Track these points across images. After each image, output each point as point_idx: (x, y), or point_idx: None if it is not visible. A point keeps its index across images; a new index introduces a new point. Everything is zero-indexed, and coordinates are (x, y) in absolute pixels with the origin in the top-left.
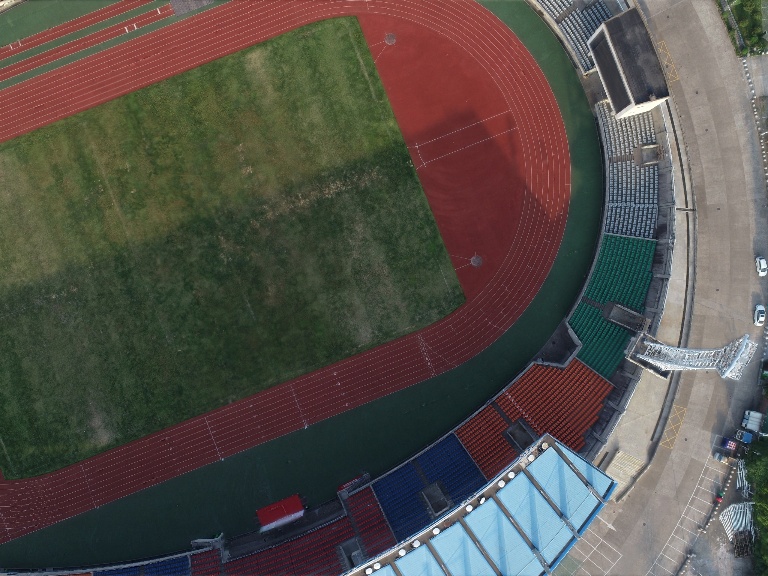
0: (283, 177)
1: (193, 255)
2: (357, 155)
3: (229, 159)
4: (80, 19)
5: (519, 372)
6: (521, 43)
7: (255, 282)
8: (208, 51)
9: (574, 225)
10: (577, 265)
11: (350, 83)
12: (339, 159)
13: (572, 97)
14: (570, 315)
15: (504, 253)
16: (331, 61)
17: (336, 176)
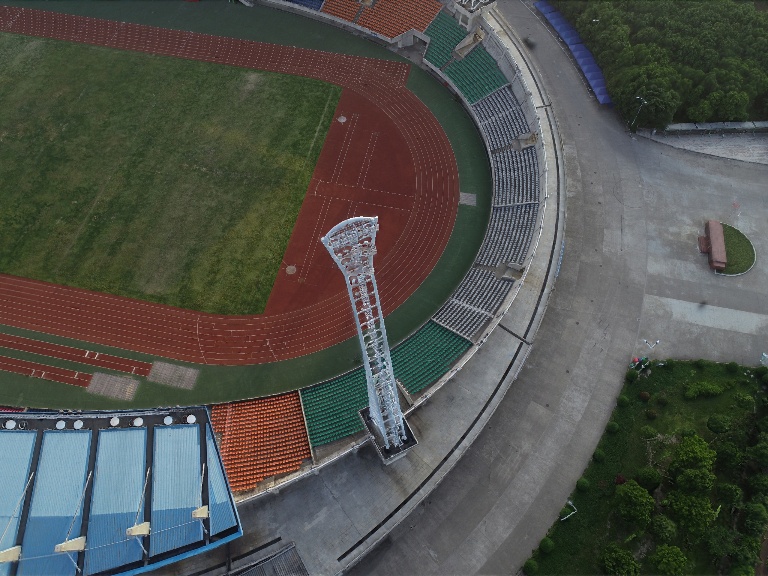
0: None
1: (81, 140)
2: None
3: None
4: None
5: None
6: None
7: (62, 104)
8: None
9: None
10: None
11: None
12: None
13: None
14: None
15: None
16: None
17: None
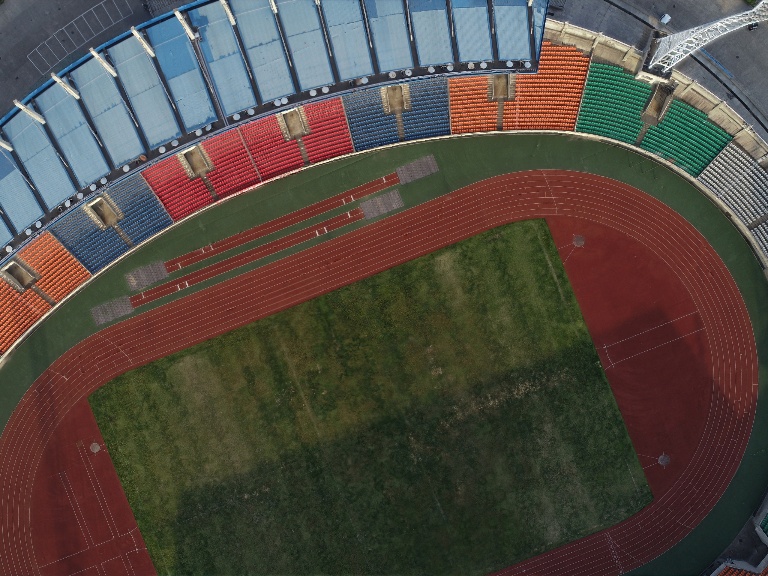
0: (473, 378)
1: (384, 455)
2: (546, 356)
3: (419, 361)
4: (271, 223)
5: (706, 569)
6: (709, 245)
7: (445, 482)
8: (398, 254)
9: (761, 424)
10: (764, 464)
11: (539, 285)
12: (528, 360)
13: (760, 298)
14: (762, 518)
15: (691, 452)
16: (520, 263)
17: (525, 377)
